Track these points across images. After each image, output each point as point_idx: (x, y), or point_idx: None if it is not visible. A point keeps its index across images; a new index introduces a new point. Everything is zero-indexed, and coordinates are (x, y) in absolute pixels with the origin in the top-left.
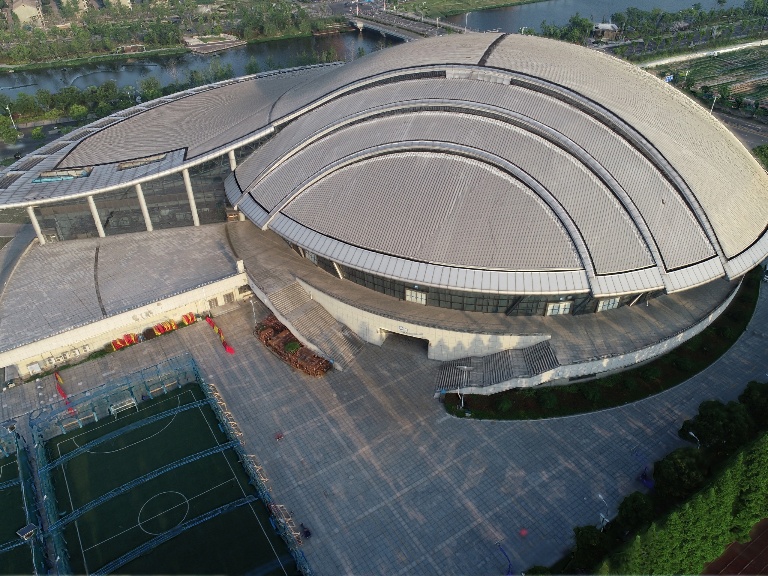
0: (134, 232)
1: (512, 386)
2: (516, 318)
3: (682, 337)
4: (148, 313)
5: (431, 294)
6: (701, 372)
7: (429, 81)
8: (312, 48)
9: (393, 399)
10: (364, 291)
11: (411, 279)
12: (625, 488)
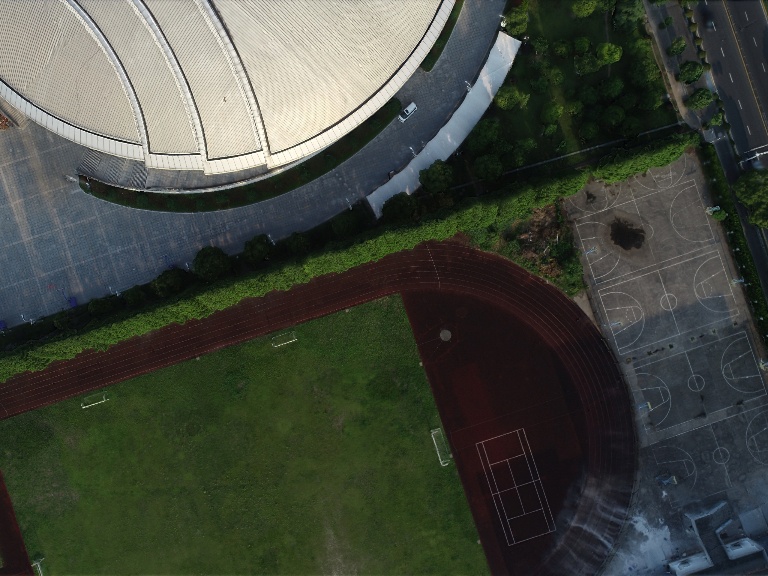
0: None
1: None
2: None
3: (248, 182)
4: None
5: None
6: (268, 200)
7: None
8: None
9: (49, 165)
10: None
11: (22, 112)
12: (160, 269)
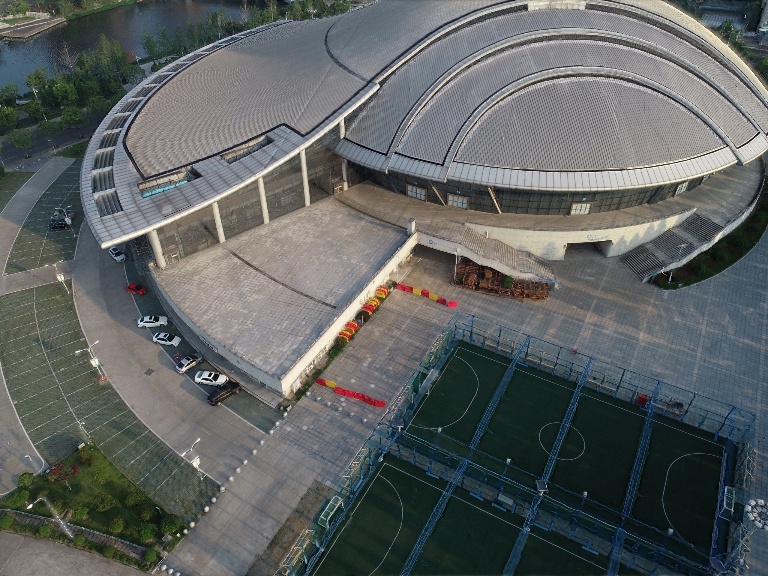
0: (251, 228)
1: (697, 253)
2: (658, 204)
3: None
4: (367, 294)
5: (595, 202)
6: None
7: (516, 16)
8: (135, 17)
9: (618, 294)
10: (530, 218)
11: (621, 186)
12: None
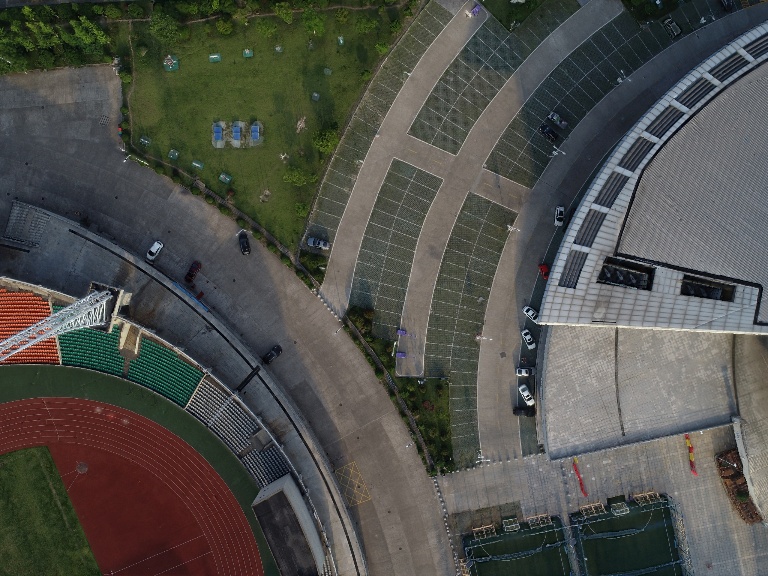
0: None
1: None
2: None
3: None
4: None
5: None
6: None
7: None
8: None
9: None
10: None
11: None
12: None
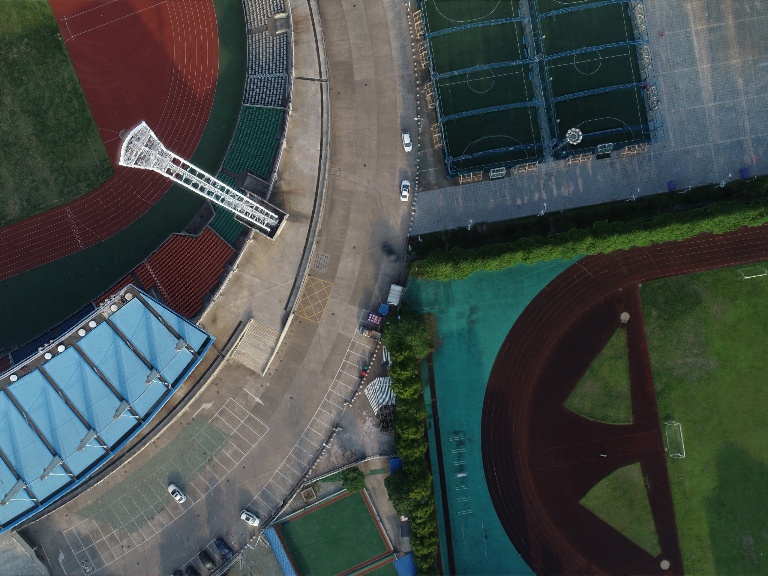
0: None
1: None
2: None
3: None
4: None
5: None
6: None
7: None
8: None
9: (742, 34)
10: None
11: None
12: None
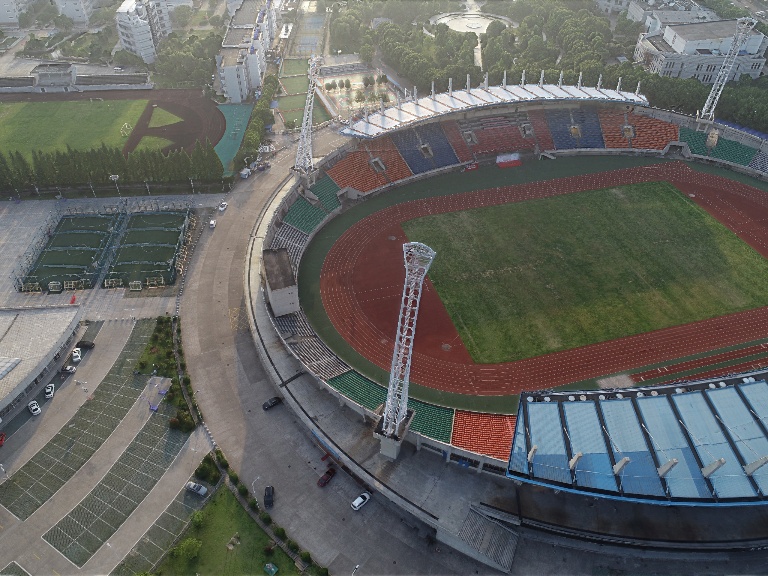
0: None
1: None
2: None
3: None
4: None
5: None
6: None
7: None
8: None
9: None
10: None
11: None
12: None
